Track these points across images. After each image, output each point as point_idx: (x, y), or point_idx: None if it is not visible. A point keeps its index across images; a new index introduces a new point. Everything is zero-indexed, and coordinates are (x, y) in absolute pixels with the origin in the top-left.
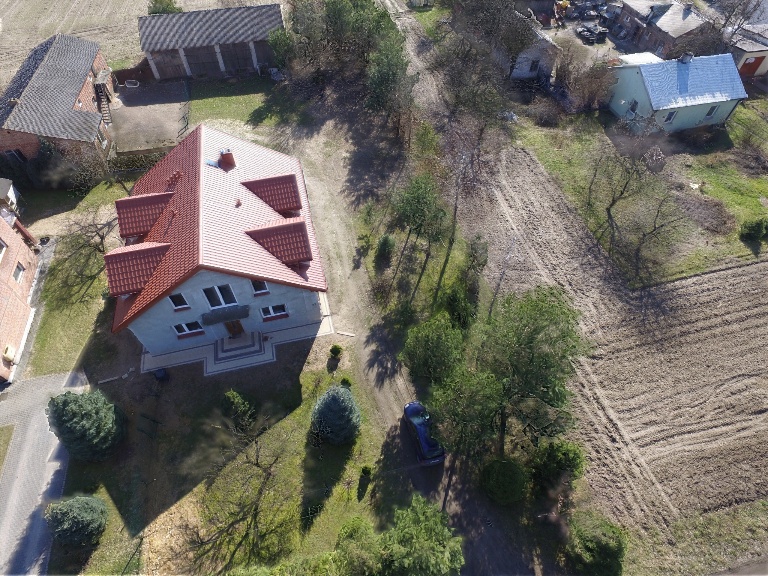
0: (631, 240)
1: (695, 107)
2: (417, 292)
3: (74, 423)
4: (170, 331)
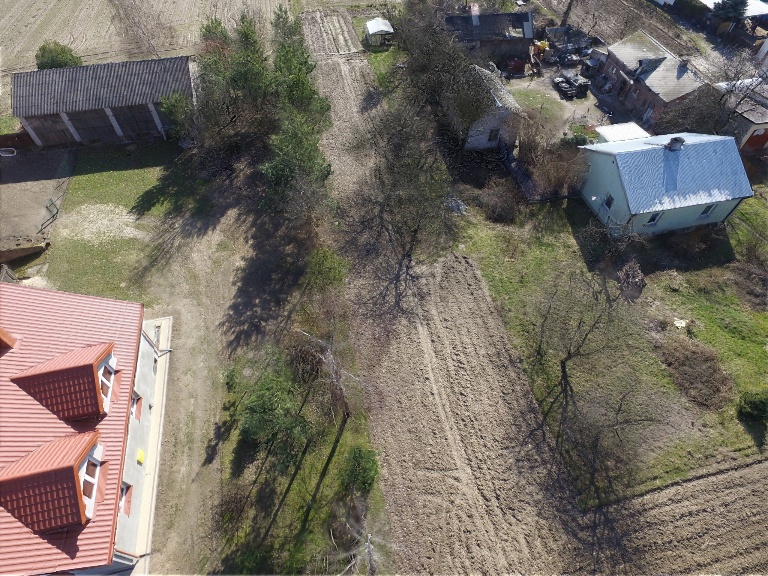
0: (589, 418)
1: (686, 208)
2: (281, 511)
3: None
4: None
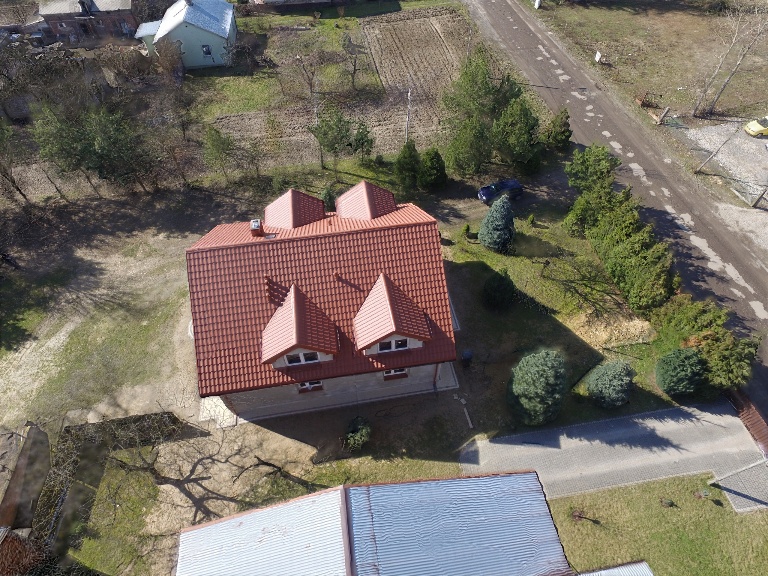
0: (345, 90)
1: None
2: None
3: None
4: None
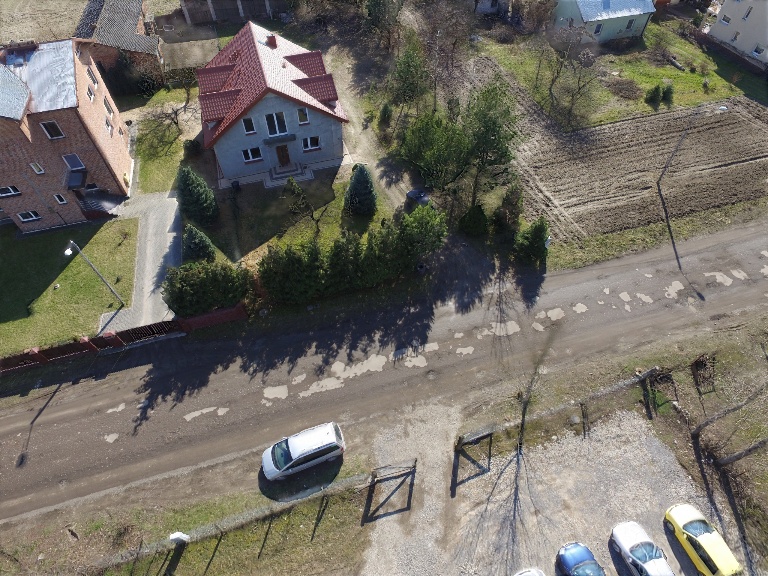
0: (566, 105)
1: (616, 20)
2: None
3: (193, 187)
4: (240, 155)
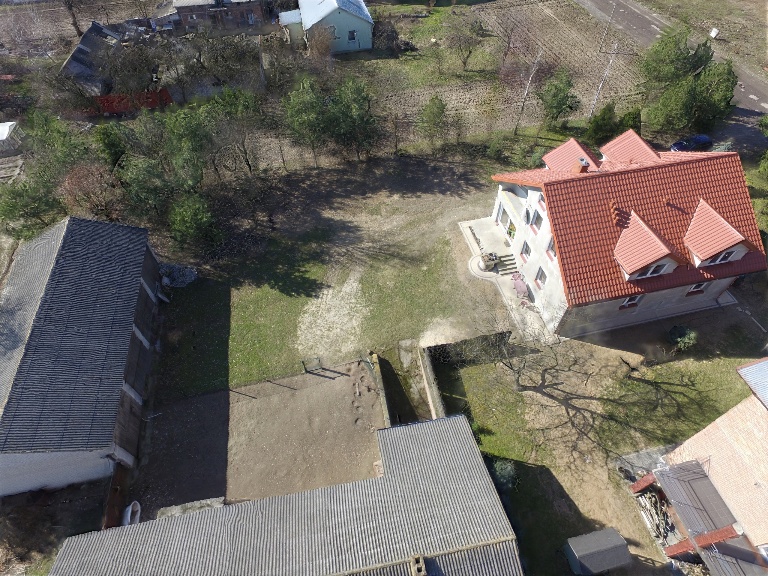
0: (495, 68)
1: None
2: None
3: None
4: None
